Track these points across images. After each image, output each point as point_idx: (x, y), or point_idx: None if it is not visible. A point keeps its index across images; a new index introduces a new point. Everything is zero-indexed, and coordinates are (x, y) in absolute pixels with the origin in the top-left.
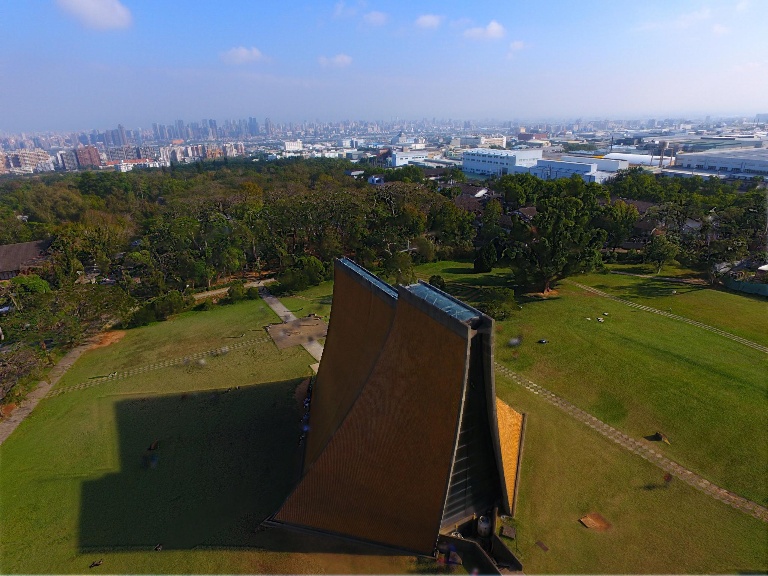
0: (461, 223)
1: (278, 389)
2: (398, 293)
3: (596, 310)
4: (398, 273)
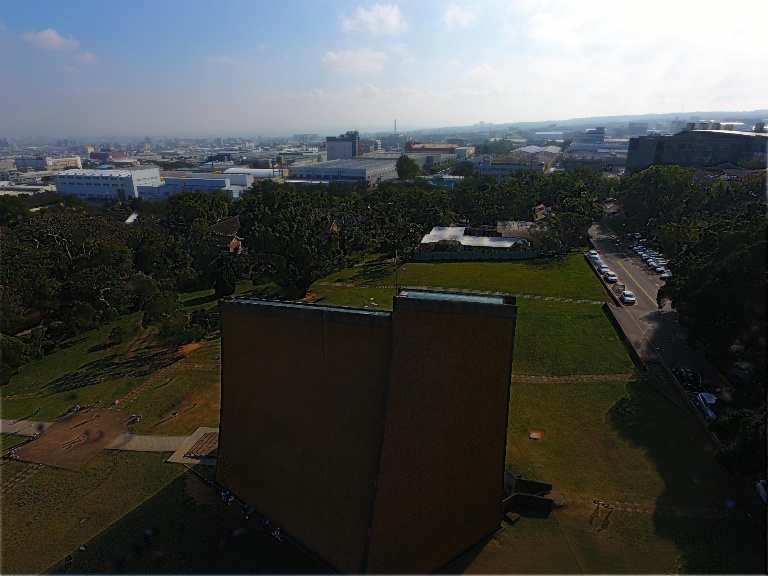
0: (170, 250)
1: (161, 509)
2: (395, 306)
3: (362, 298)
4: (165, 318)
